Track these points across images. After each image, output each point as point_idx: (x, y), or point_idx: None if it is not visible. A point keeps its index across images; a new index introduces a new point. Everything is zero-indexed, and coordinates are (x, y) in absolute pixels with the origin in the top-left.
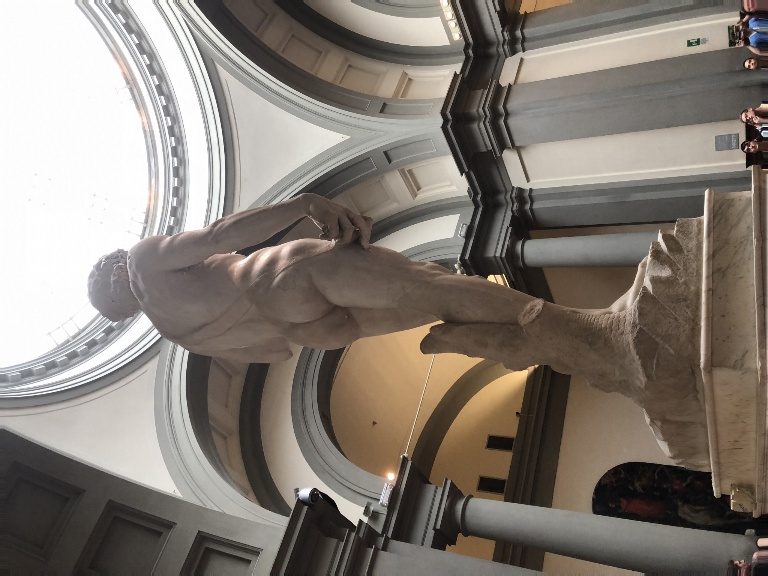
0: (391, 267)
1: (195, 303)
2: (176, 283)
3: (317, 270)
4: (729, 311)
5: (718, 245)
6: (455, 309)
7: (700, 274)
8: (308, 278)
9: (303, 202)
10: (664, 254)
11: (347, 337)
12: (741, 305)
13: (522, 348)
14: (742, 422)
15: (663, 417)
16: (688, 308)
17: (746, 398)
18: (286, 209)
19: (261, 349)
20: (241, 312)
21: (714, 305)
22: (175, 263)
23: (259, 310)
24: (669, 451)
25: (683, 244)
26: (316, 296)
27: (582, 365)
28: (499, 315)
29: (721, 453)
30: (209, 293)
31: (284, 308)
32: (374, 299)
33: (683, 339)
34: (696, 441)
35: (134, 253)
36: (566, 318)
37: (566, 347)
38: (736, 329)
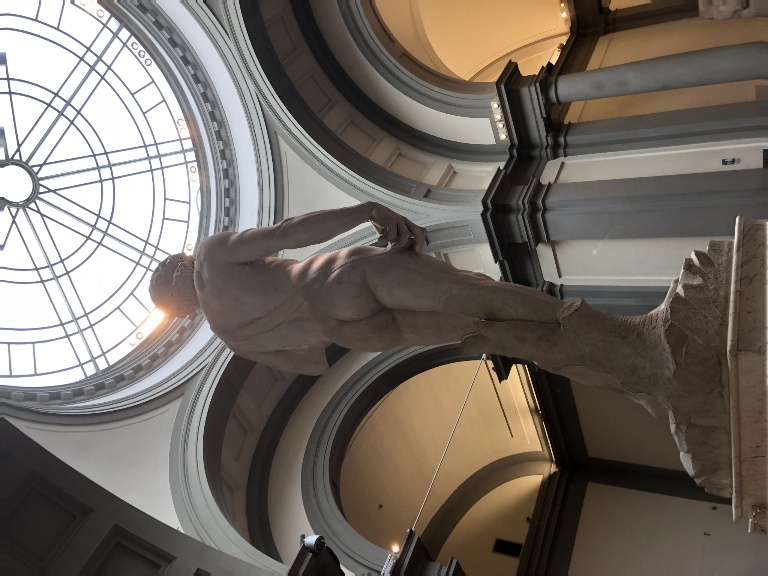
0: (440, 271)
1: (252, 295)
2: (238, 275)
3: (372, 268)
4: (755, 308)
5: (746, 258)
6: (498, 307)
7: (729, 282)
8: (362, 275)
9: (367, 207)
10: (696, 267)
11: (389, 340)
12: (766, 304)
13: (558, 344)
14: (765, 421)
15: (688, 420)
16: (717, 308)
17: None
18: (351, 212)
19: (301, 358)
20: (293, 308)
21: (741, 303)
22: (241, 255)
23: (310, 307)
24: (692, 467)
25: (714, 259)
26: (367, 293)
27: (614, 360)
28: (539, 314)
29: (743, 463)
30: (266, 287)
31: (336, 301)
32: (421, 299)
33: (711, 332)
34: (719, 453)
35: (204, 244)
36: (602, 316)
37: (600, 342)
38: (761, 322)
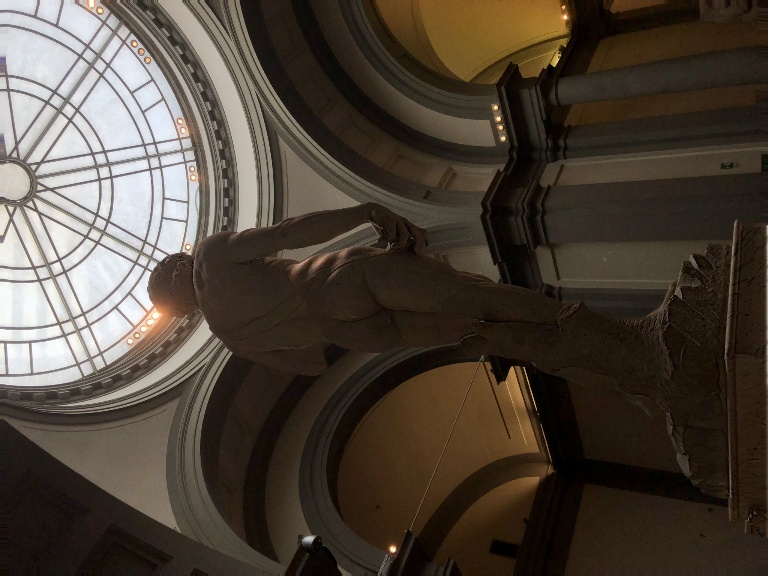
0: (439, 272)
1: (251, 294)
2: (237, 274)
3: (371, 269)
4: (753, 311)
5: (745, 261)
6: (496, 308)
7: (727, 285)
8: (362, 275)
9: (367, 207)
10: (694, 270)
11: (388, 340)
12: (764, 307)
13: (556, 345)
14: (762, 424)
15: (686, 423)
16: (715, 311)
17: (766, 393)
18: (350, 212)
19: (299, 358)
20: (292, 308)
21: (739, 306)
22: (240, 254)
23: (309, 307)
24: (689, 469)
25: (712, 262)
26: (366, 293)
27: (612, 362)
28: (537, 316)
29: (740, 465)
30: (266, 287)
31: (335, 301)
32: (420, 300)
33: (709, 335)
34: (716, 456)
35: (204, 243)
36: (600, 318)
37: (598, 343)
38: (759, 325)
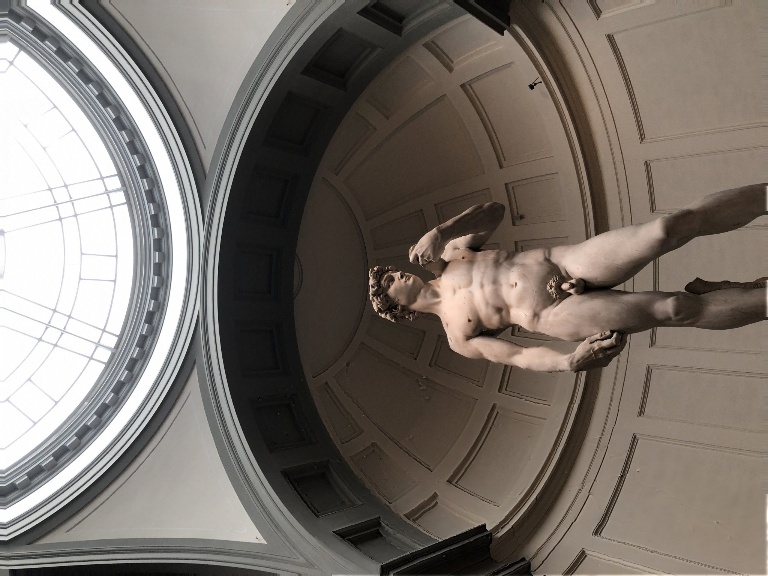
0: None
1: None
2: None
3: None
4: None
5: None
6: None
7: None
8: None
9: None
10: None
11: None
12: None
13: None
14: None
15: None
16: None
17: None
18: None
19: None
20: None
21: None
22: None
23: None
24: None
25: None
26: None
27: None
28: None
29: None
30: None
31: None
32: None
33: None
34: None
35: None
36: None
37: None
38: None
